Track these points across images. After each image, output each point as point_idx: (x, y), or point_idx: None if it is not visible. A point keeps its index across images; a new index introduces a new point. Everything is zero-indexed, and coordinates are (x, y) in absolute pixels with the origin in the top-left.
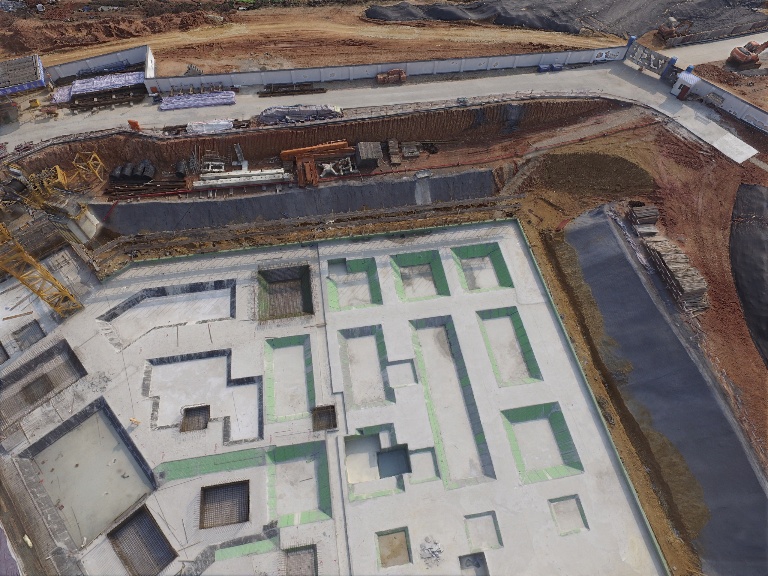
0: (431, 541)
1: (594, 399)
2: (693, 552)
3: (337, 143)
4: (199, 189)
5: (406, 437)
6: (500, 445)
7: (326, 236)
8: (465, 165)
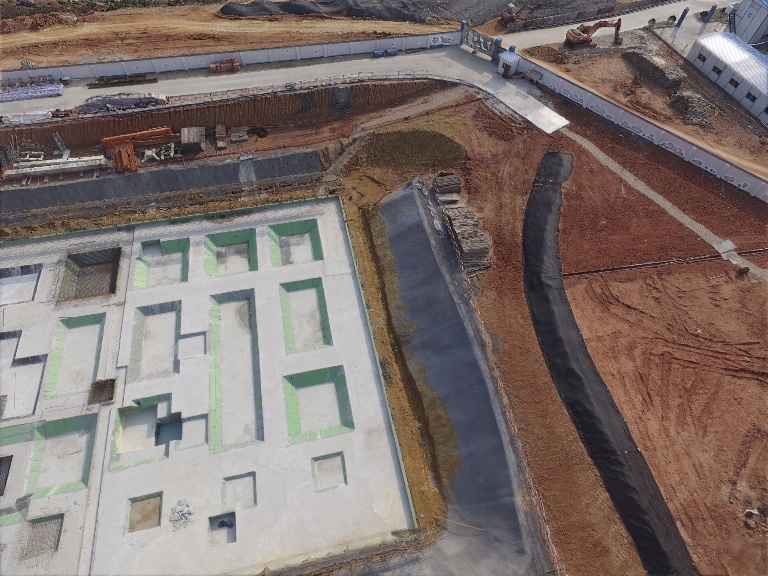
0: (184, 504)
1: (377, 360)
2: (443, 500)
3: (160, 129)
4: (13, 178)
5: (181, 406)
6: (275, 409)
7: (142, 219)
8: (292, 147)
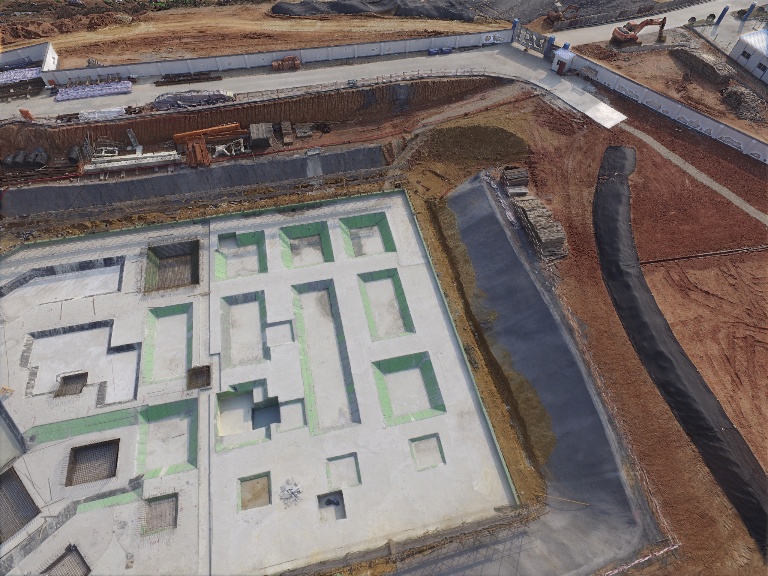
0: (292, 483)
1: (461, 346)
2: (541, 477)
3: (229, 125)
4: (91, 173)
5: (277, 390)
6: (368, 393)
7: (217, 212)
8: (356, 142)
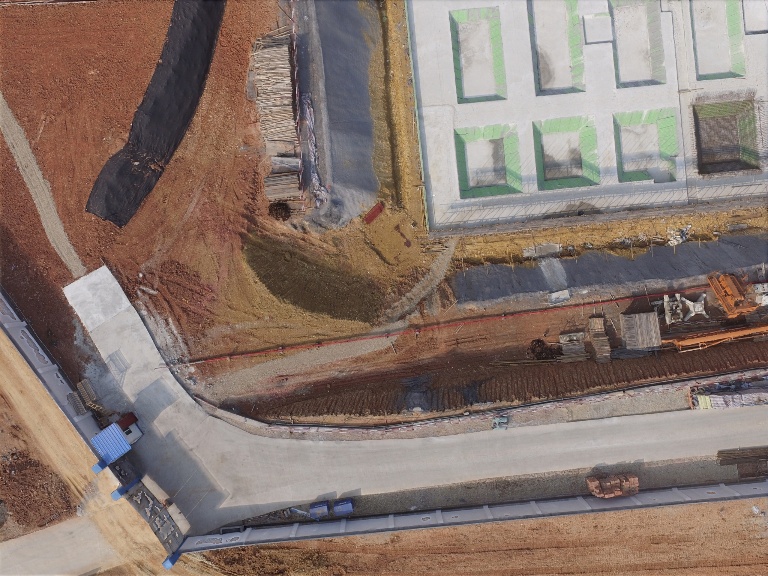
0: None
1: None
2: None
3: (694, 342)
4: None
5: None
6: None
7: None
8: (495, 315)
